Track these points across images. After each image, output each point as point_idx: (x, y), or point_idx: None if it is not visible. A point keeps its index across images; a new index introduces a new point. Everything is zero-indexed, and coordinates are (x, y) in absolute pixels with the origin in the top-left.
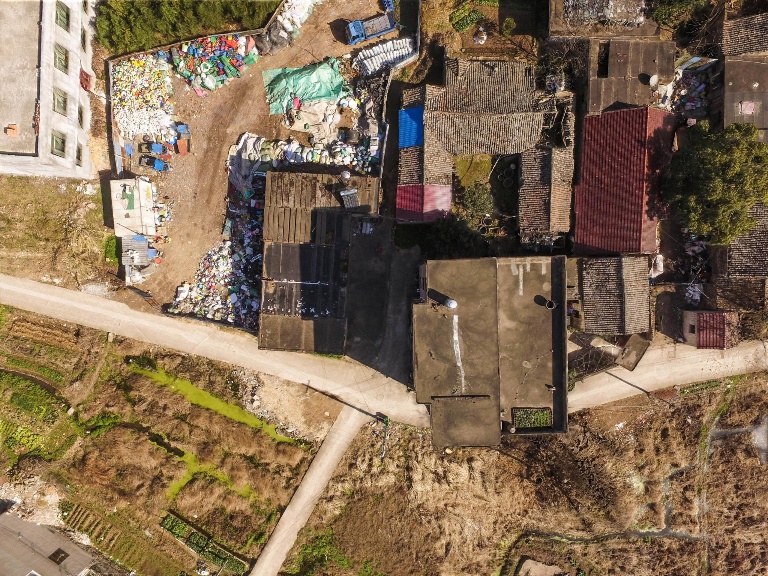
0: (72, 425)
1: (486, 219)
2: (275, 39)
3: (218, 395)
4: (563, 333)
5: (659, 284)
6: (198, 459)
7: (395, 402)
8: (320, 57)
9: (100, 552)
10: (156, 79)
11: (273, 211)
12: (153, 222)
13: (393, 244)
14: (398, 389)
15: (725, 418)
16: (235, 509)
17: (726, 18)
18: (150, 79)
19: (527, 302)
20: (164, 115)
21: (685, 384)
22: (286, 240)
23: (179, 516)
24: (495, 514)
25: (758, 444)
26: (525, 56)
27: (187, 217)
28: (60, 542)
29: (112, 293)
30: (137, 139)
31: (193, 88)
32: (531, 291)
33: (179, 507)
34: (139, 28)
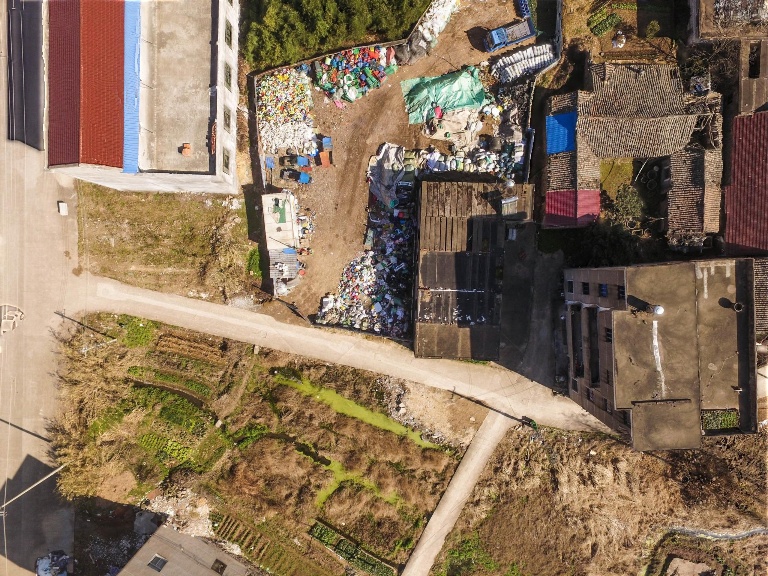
0: (220, 437)
1: (630, 222)
2: (415, 49)
3: (363, 404)
4: (750, 335)
5: None
6: (345, 467)
7: (541, 406)
8: (458, 65)
9: (250, 562)
10: (299, 93)
11: (429, 221)
12: (297, 234)
13: (536, 249)
14: (543, 393)
15: None
16: (382, 516)
17: None
18: (294, 93)
19: (712, 305)
20: (307, 128)
21: None
22: (443, 249)
23: (327, 524)
24: (640, 514)
25: None
26: (664, 58)
27: (329, 228)
28: (215, 553)
29: (258, 306)
30: (280, 153)
31: (333, 100)
32: (716, 294)
33: (328, 515)
34: (290, 43)
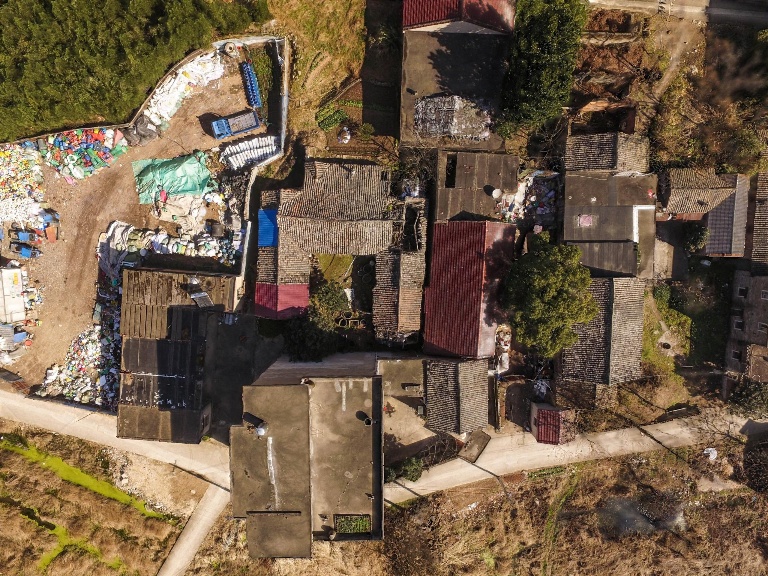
0: None
1: (346, 312)
2: (143, 132)
3: (88, 472)
4: None
5: (509, 377)
6: (68, 532)
7: None
8: (189, 149)
9: None
10: (23, 169)
11: (130, 308)
12: (22, 307)
13: (257, 333)
14: None
15: (570, 500)
16: None
17: (569, 134)
18: (17, 169)
19: (349, 417)
20: (32, 204)
21: (533, 469)
22: (142, 336)
23: None
24: None
25: (600, 524)
26: (387, 156)
27: (58, 301)
28: None
29: None
30: (6, 226)
31: (63, 176)
32: (353, 407)
33: None
34: None
